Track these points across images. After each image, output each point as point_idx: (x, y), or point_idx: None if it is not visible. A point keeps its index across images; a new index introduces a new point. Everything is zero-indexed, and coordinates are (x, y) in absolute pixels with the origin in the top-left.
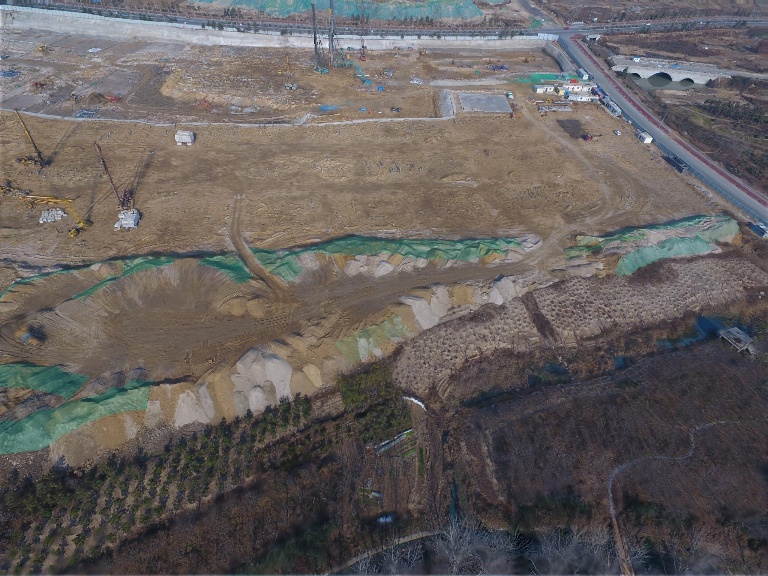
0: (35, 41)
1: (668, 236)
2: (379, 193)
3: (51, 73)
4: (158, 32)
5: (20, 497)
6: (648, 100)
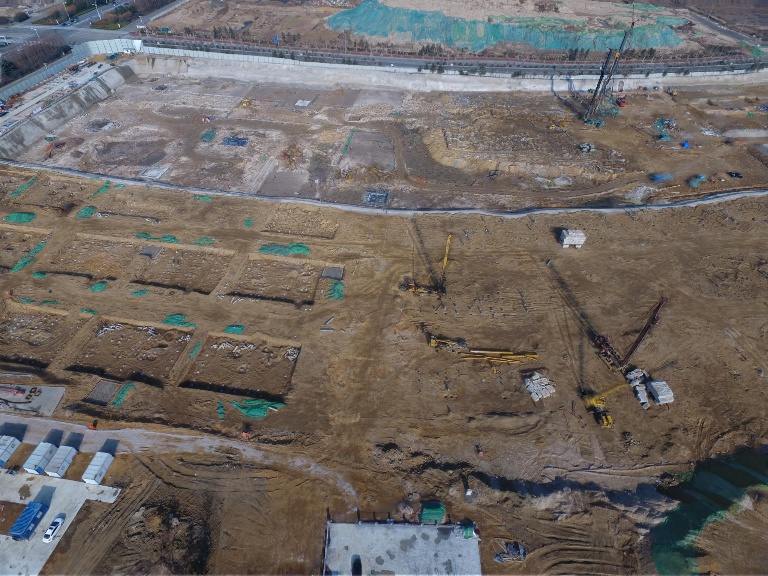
0: (227, 94)
1: None
2: None
3: (285, 139)
4: (364, 78)
5: None
6: None
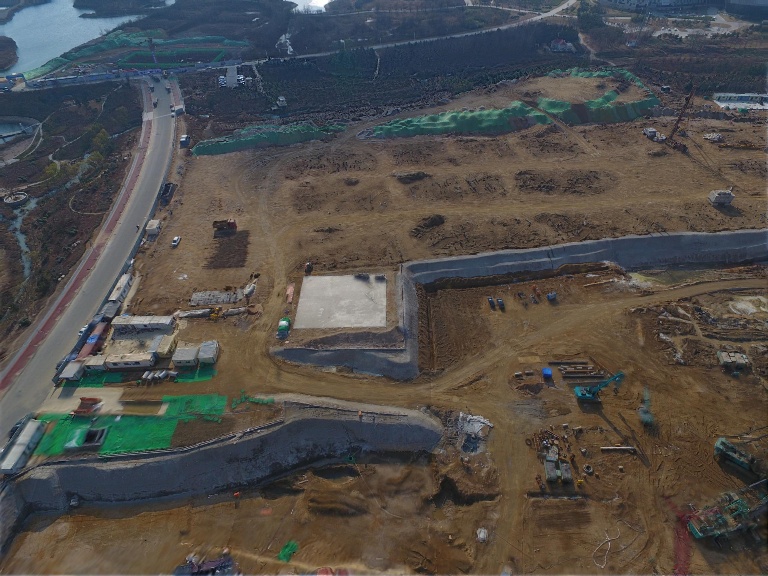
0: None
1: (269, 128)
2: (481, 162)
3: None
4: None
5: None
6: (6, 333)
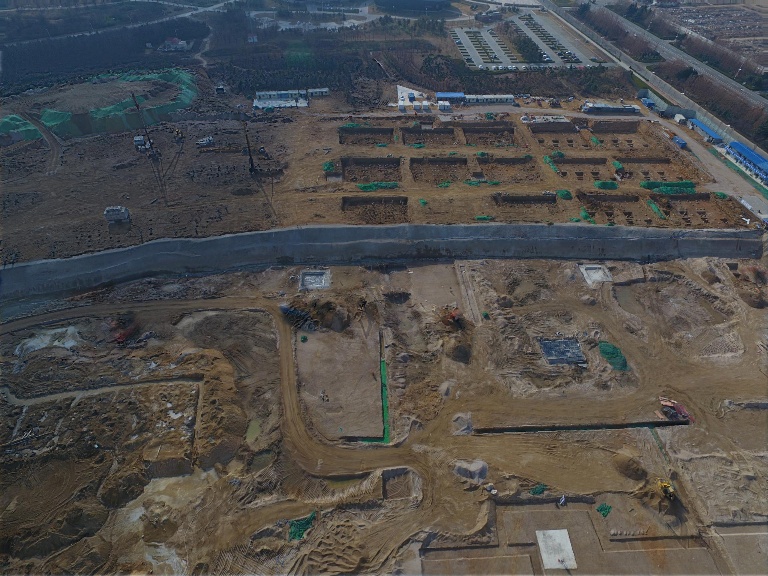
0: None
1: None
2: None
3: (491, 372)
4: None
5: None
6: None
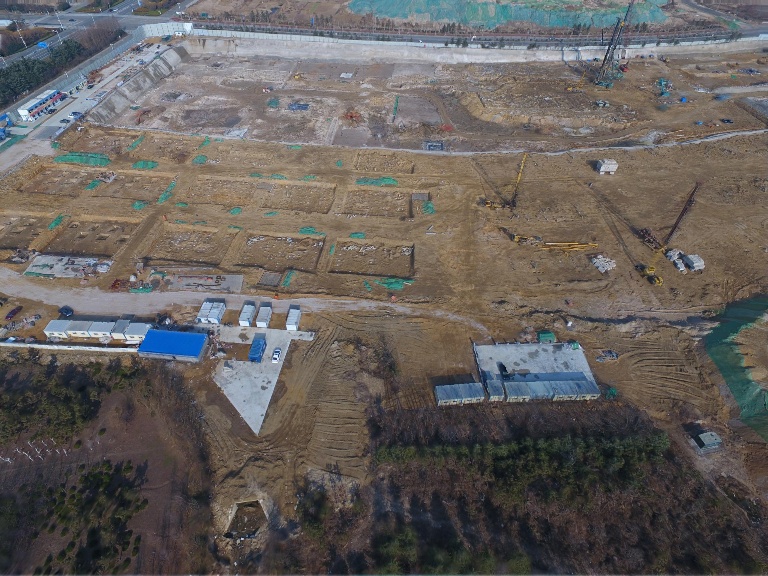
0: (276, 69)
1: None
2: None
3: (341, 103)
4: (397, 52)
5: None
6: None
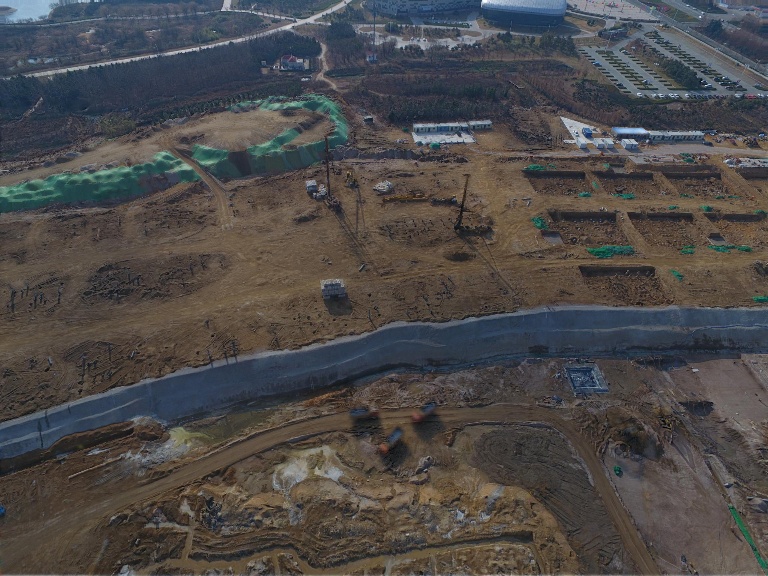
0: None
1: None
2: (61, 253)
3: None
4: None
5: (266, 98)
6: None
